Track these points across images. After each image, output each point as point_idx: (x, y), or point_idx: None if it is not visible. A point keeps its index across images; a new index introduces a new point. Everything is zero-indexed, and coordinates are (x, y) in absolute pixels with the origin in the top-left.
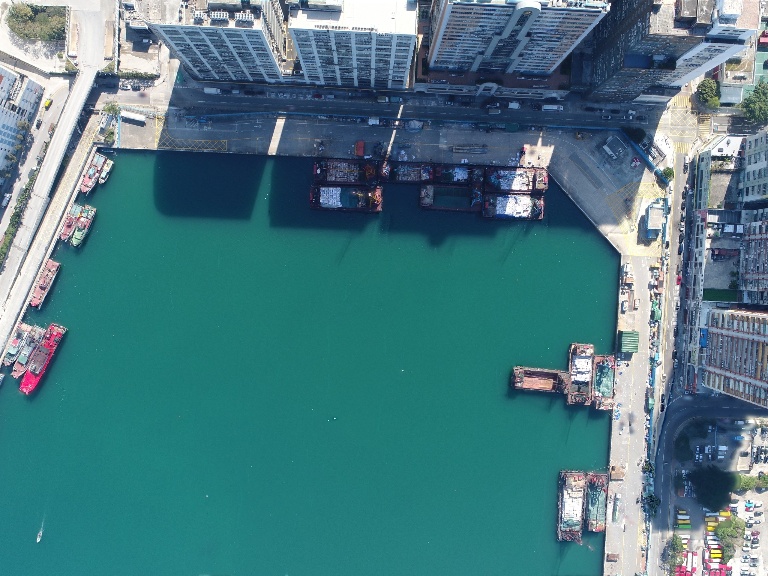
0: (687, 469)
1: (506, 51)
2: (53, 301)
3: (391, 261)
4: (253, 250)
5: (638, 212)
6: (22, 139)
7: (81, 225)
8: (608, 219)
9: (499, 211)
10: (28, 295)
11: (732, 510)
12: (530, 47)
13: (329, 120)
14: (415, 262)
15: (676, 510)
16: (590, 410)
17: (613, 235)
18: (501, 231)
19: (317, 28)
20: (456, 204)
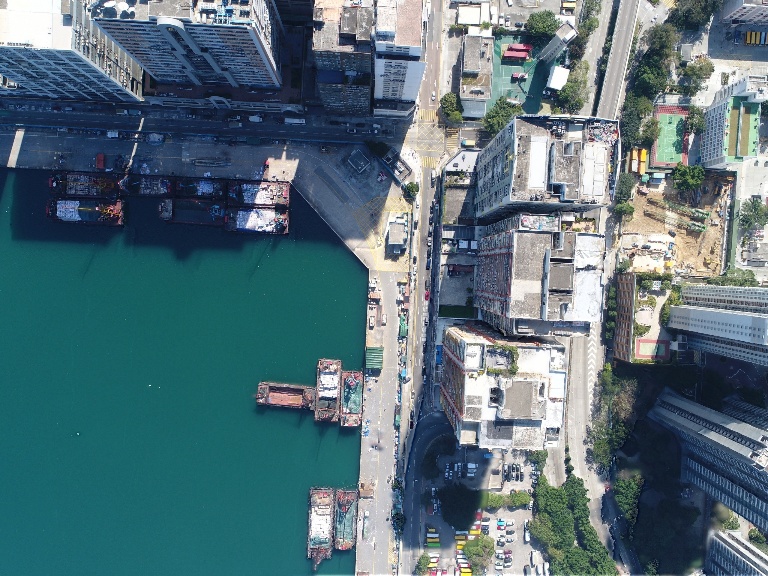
0: (437, 487)
1: (208, 65)
2: None
3: (135, 275)
4: None
5: (385, 227)
6: None
7: None
8: (355, 234)
9: (240, 225)
10: None
11: (483, 528)
12: (226, 62)
13: (69, 133)
14: (159, 276)
15: (426, 528)
16: (341, 426)
17: (360, 250)
18: (247, 245)
19: None
20: (198, 218)
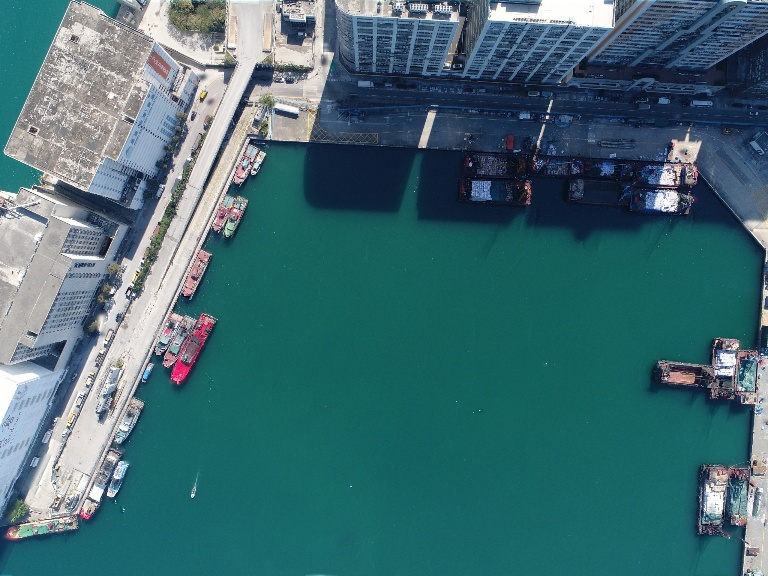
0: None
1: (678, 46)
2: (202, 291)
3: (537, 255)
4: (401, 242)
5: None
6: (180, 130)
7: (234, 216)
8: (753, 215)
9: (648, 206)
10: (179, 285)
11: None
12: (705, 42)
13: (479, 114)
14: (561, 256)
15: None
16: (731, 405)
17: (758, 231)
18: (646, 226)
19: (516, 21)
20: (604, 198)
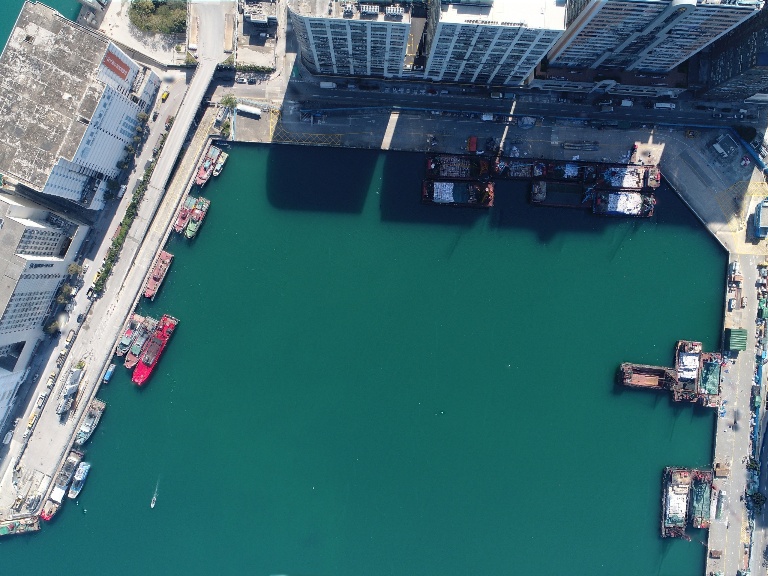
0: None
1: (635, 48)
2: (164, 292)
3: (500, 256)
4: (364, 244)
5: (747, 210)
6: (141, 131)
7: (196, 217)
8: (717, 217)
9: (611, 208)
10: (141, 286)
11: None
12: (662, 44)
13: (442, 115)
14: (524, 258)
15: None
16: (695, 407)
17: (722, 233)
18: (610, 228)
19: (467, 23)
20: (567, 200)
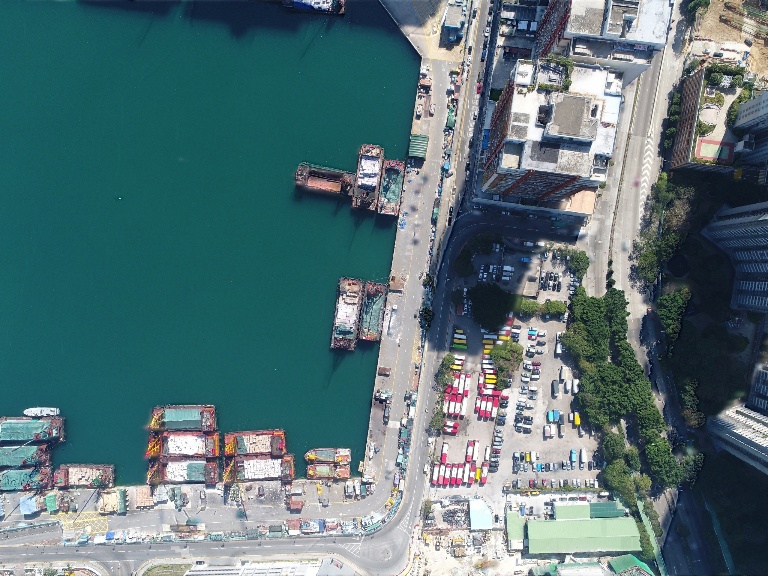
0: None
1: None
2: None
3: (189, 45)
4: (58, 24)
5: (443, 14)
6: None
7: None
8: (411, 19)
9: None
10: None
11: (513, 336)
12: None
13: None
14: (212, 48)
15: (454, 329)
16: (377, 218)
17: (415, 36)
18: (302, 24)
19: None
20: None
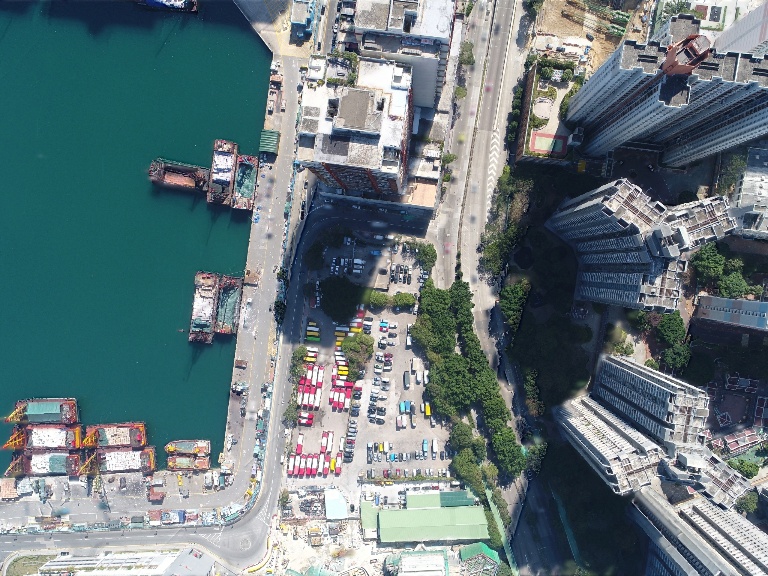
0: None
1: None
2: None
3: (47, 43)
4: None
5: None
6: None
7: None
8: (262, 16)
9: None
10: None
11: (365, 328)
12: None
13: None
14: (69, 46)
15: (308, 322)
16: (233, 212)
17: (266, 33)
18: (157, 21)
19: None
20: None
